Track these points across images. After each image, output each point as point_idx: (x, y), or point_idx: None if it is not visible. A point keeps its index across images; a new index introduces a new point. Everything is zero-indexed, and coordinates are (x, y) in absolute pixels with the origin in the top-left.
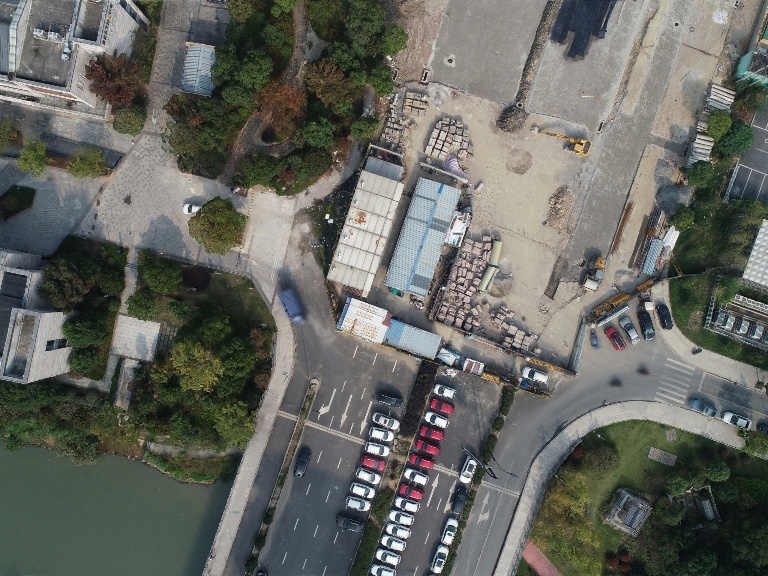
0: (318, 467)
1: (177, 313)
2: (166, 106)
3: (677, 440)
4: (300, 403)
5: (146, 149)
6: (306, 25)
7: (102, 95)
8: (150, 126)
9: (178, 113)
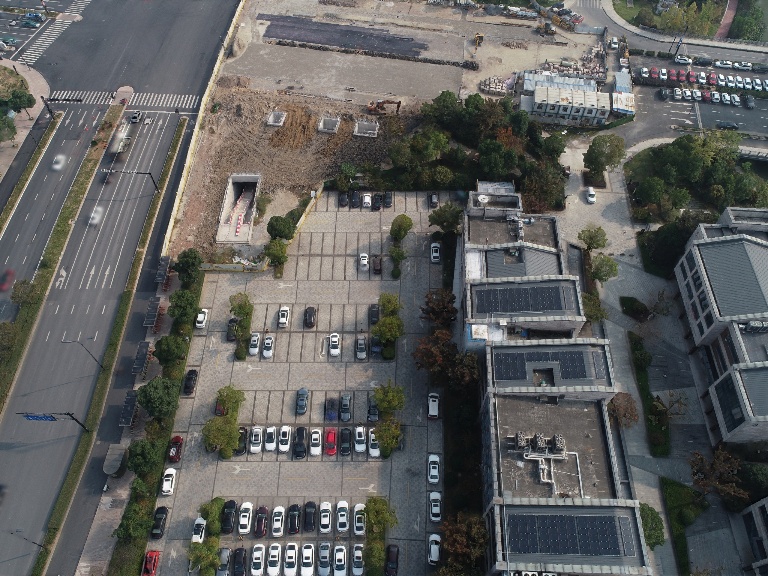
0: (725, 121)
1: (675, 167)
2: None
3: (618, 0)
4: (690, 133)
5: None
6: None
7: None
8: None
9: None
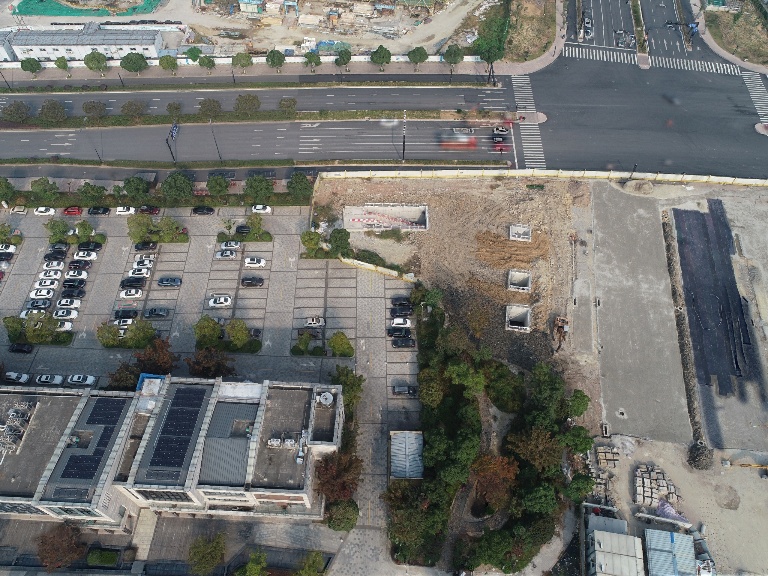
0: None
1: None
2: (387, 495)
3: None
4: None
5: (356, 545)
6: (487, 402)
7: (328, 493)
8: (357, 519)
9: (400, 500)
